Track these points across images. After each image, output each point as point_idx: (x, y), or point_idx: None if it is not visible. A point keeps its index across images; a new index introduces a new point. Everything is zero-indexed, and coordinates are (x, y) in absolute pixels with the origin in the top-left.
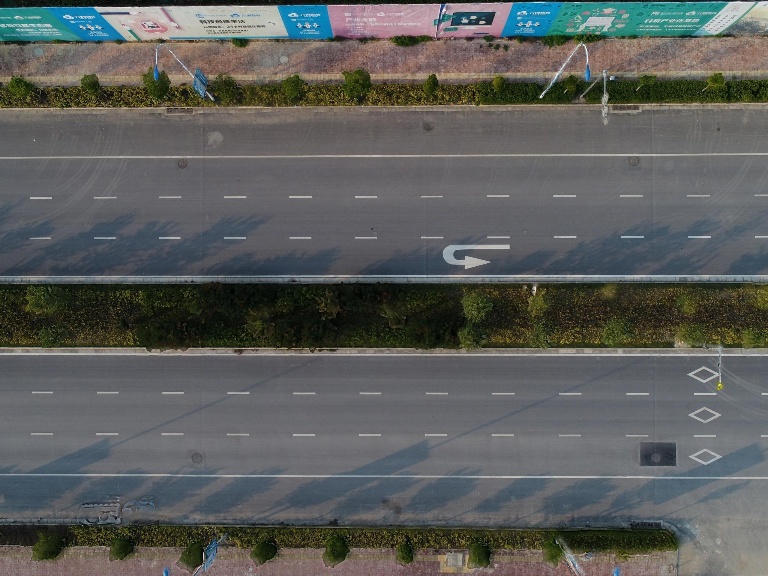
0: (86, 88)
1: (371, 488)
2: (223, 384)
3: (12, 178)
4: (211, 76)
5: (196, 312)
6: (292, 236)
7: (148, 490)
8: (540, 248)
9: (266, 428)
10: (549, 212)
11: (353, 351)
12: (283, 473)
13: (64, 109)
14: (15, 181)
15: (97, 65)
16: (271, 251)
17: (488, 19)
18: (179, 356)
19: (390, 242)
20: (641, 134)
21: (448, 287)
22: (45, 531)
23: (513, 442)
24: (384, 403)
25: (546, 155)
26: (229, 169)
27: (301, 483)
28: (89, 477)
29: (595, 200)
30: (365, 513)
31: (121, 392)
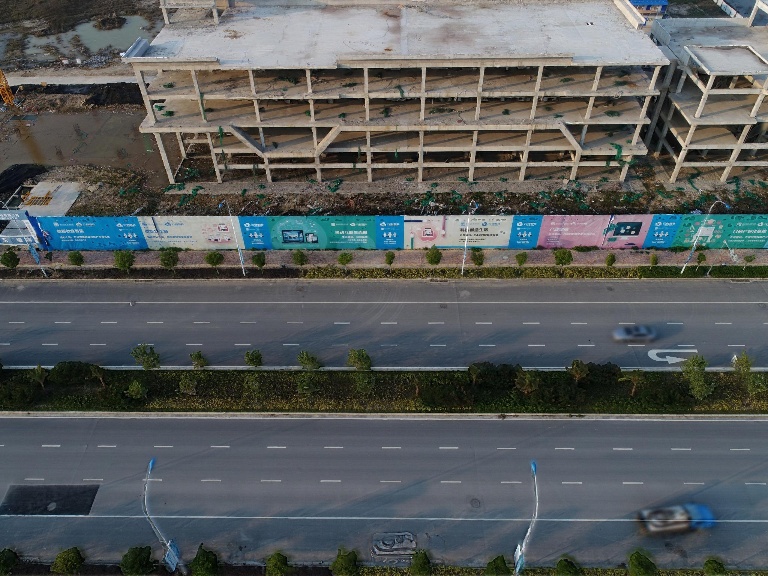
0: (378, 268)
1: (649, 532)
2: (492, 441)
3: (322, 313)
4: (459, 265)
5: (475, 372)
6: (530, 344)
7: (430, 533)
8: (721, 352)
9: None
10: (717, 332)
11: (598, 417)
12: (560, 517)
13: (361, 280)
14: (324, 314)
15: (384, 260)
16: (516, 353)
17: (637, 229)
18: (452, 420)
19: (605, 348)
20: (759, 293)
21: (661, 374)
22: (327, 572)
23: (767, 489)
24: (637, 457)
25: (699, 302)
26: (477, 309)
27: (579, 526)
28: (373, 520)
29: (747, 325)
30: (651, 557)
31: (403, 447)
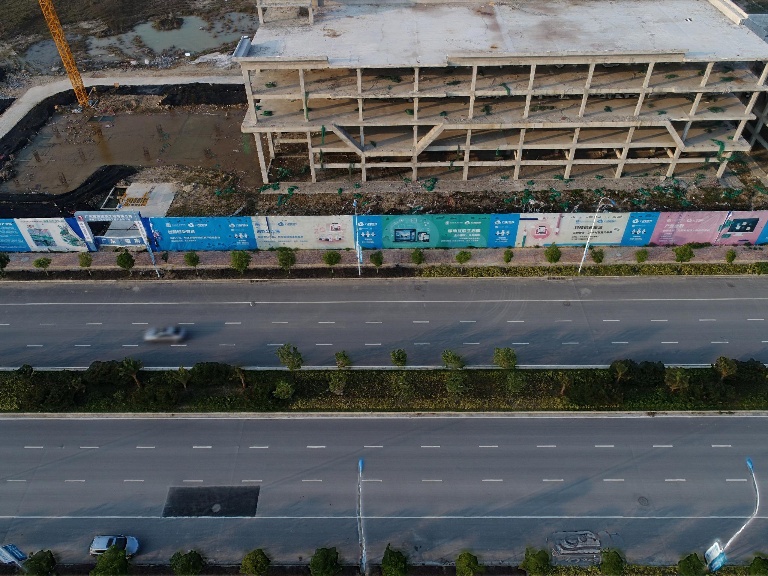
0: (493, 267)
1: None
2: (646, 439)
3: (446, 311)
4: (573, 262)
5: (623, 370)
6: (663, 341)
7: None
8: None
9: (699, 474)
10: None
11: (748, 414)
12: (732, 514)
13: (477, 278)
14: (448, 313)
15: (497, 258)
16: (651, 350)
17: (753, 226)
18: (601, 418)
19: (740, 345)
20: None
21: None
22: (510, 572)
23: None
24: None
25: None
26: (601, 306)
27: (754, 524)
28: (544, 519)
29: None
30: None
31: (558, 446)
